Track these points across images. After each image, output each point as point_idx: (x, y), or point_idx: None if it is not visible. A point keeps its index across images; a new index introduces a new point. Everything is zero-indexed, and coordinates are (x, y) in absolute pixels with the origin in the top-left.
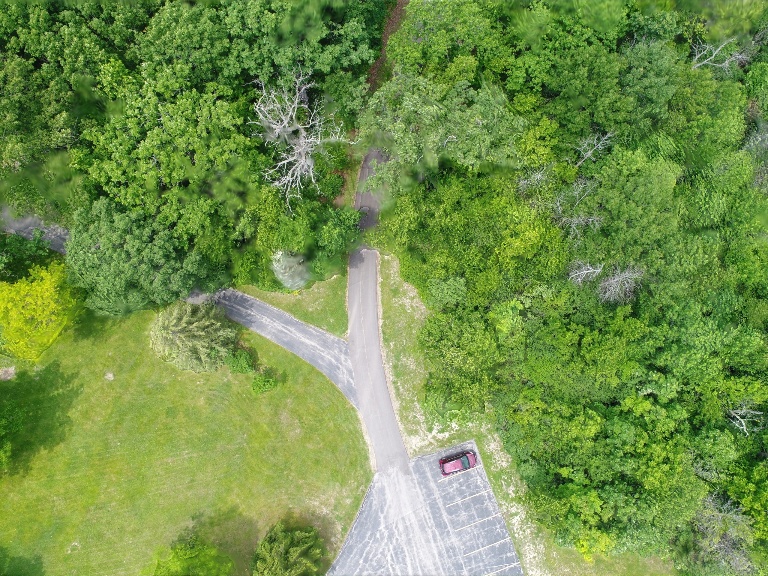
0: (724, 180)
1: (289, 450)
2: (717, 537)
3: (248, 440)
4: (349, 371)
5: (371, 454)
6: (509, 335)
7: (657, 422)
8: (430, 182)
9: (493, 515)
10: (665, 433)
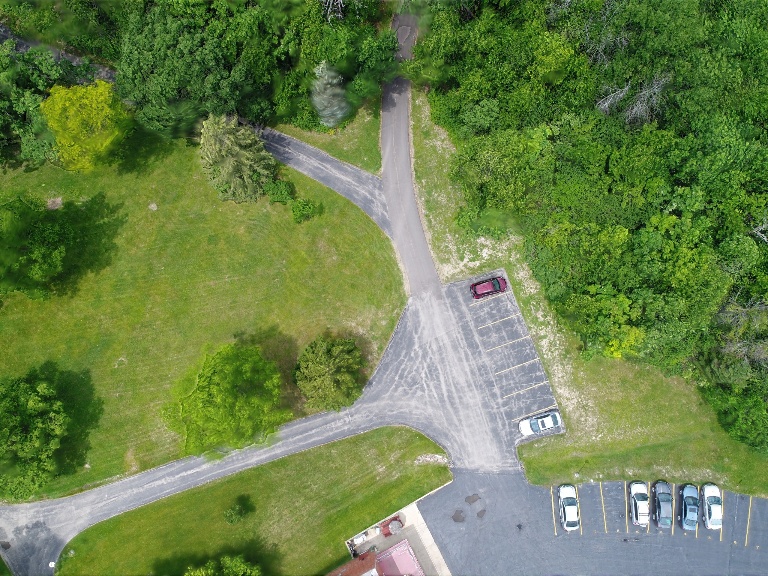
0: (745, 4)
1: (326, 275)
2: (741, 328)
3: (287, 265)
4: (383, 205)
5: (405, 280)
6: (539, 157)
7: (682, 234)
8: (464, 7)
9: (523, 337)
10: (690, 244)
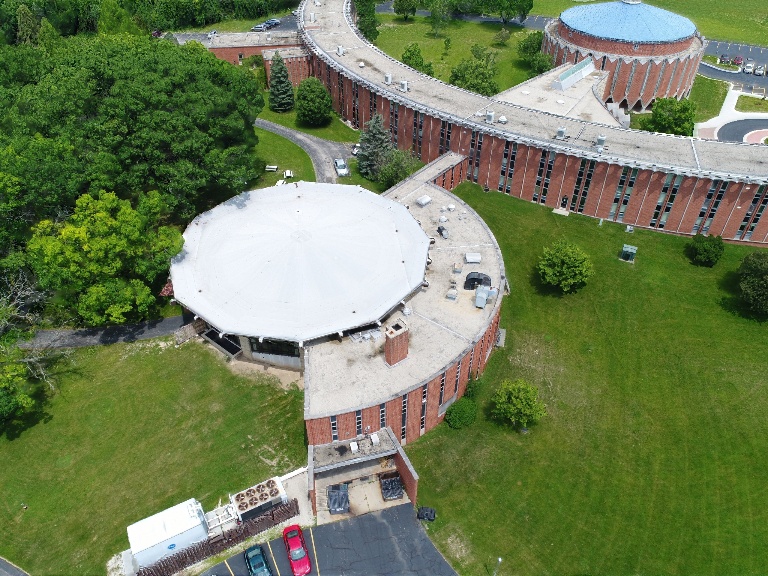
0: None
1: None
2: None
3: None
4: None
5: None
6: None
7: None
8: None
9: None
10: None
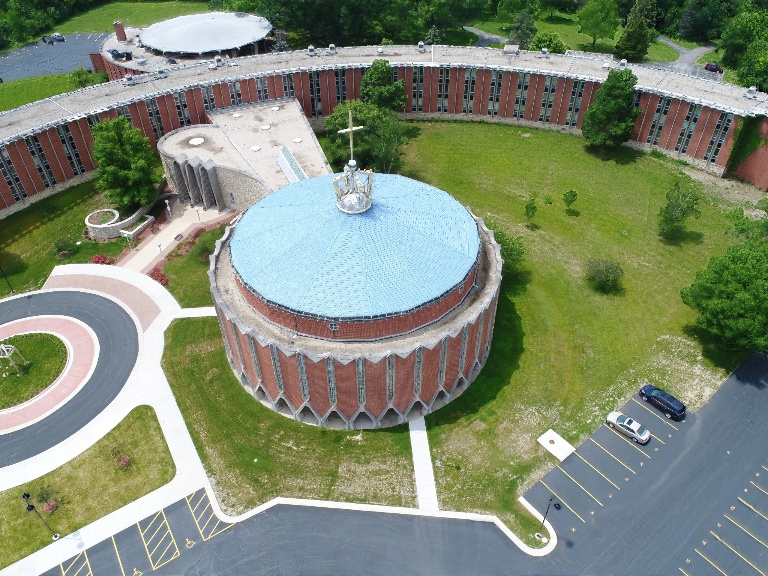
0: None
1: None
2: None
3: None
4: None
5: None
6: (765, 42)
7: None
8: None
9: None
10: None
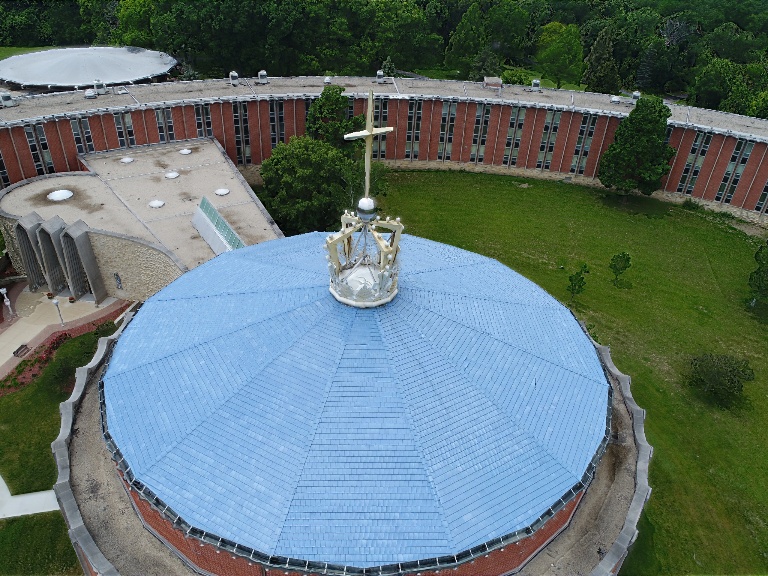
0: None
1: None
2: None
3: None
4: None
5: None
6: None
7: None
8: None
9: None
10: None
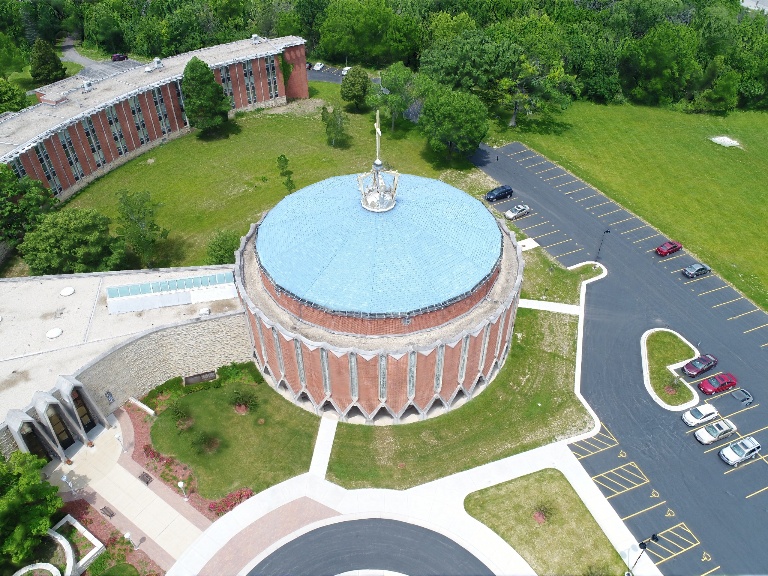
0: None
1: None
2: None
3: None
4: None
5: None
6: None
7: None
8: None
9: None
10: None
